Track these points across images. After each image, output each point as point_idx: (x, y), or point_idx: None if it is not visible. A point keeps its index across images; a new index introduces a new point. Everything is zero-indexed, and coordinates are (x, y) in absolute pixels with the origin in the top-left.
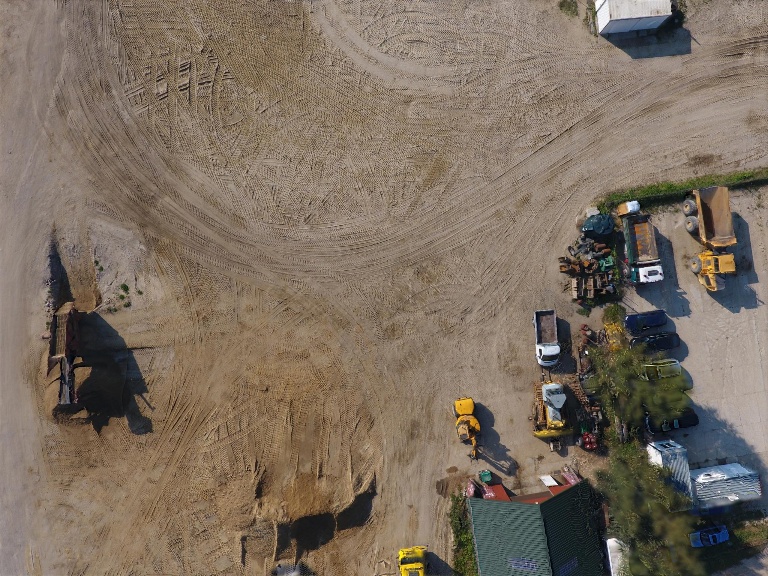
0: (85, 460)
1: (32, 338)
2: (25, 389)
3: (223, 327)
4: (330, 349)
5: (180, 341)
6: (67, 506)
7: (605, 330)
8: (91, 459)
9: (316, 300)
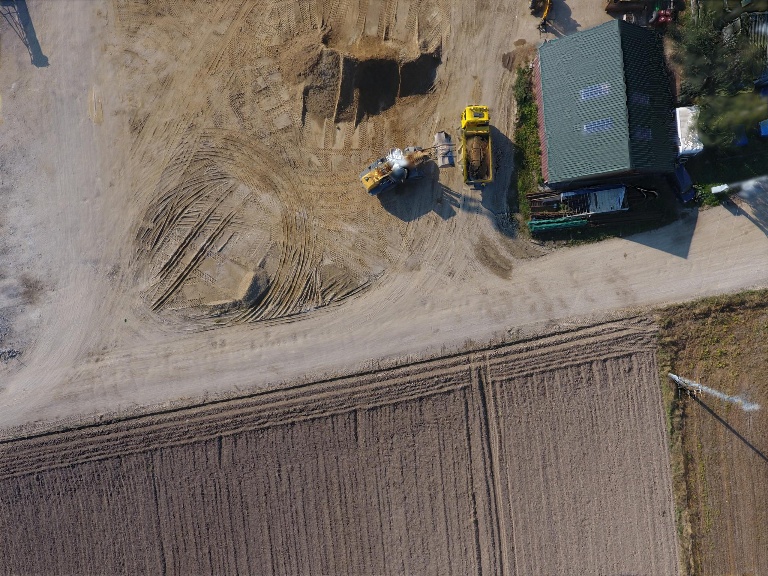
0: (153, 8)
1: None
2: None
3: None
4: None
5: None
6: (132, 53)
7: None
8: (159, 8)
9: None
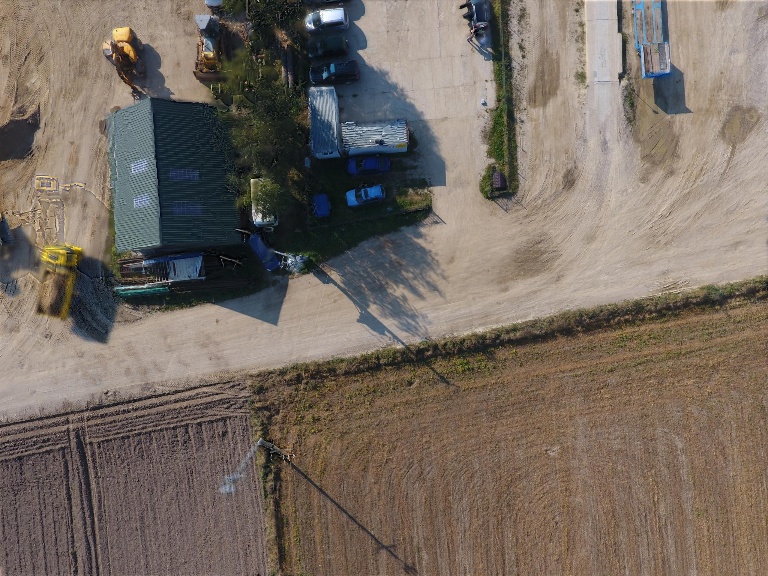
0: None
1: None
2: None
3: None
4: None
5: None
6: None
7: None
8: None
9: None
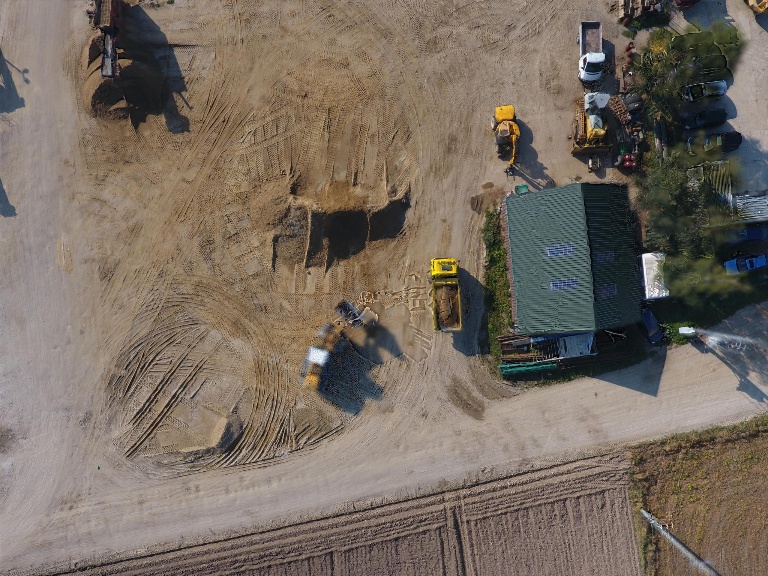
0: (121, 156)
1: (74, 31)
2: (65, 81)
3: (265, 30)
4: (371, 59)
5: (221, 41)
6: (101, 201)
7: (650, 54)
8: (127, 155)
9: (359, 9)
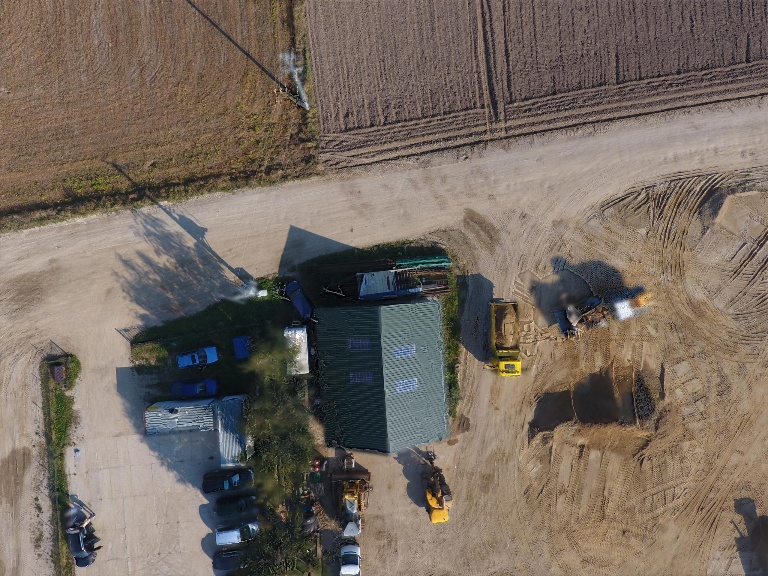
0: None
1: None
2: None
3: None
4: (560, 567)
5: None
6: None
7: (286, 570)
8: None
9: None
